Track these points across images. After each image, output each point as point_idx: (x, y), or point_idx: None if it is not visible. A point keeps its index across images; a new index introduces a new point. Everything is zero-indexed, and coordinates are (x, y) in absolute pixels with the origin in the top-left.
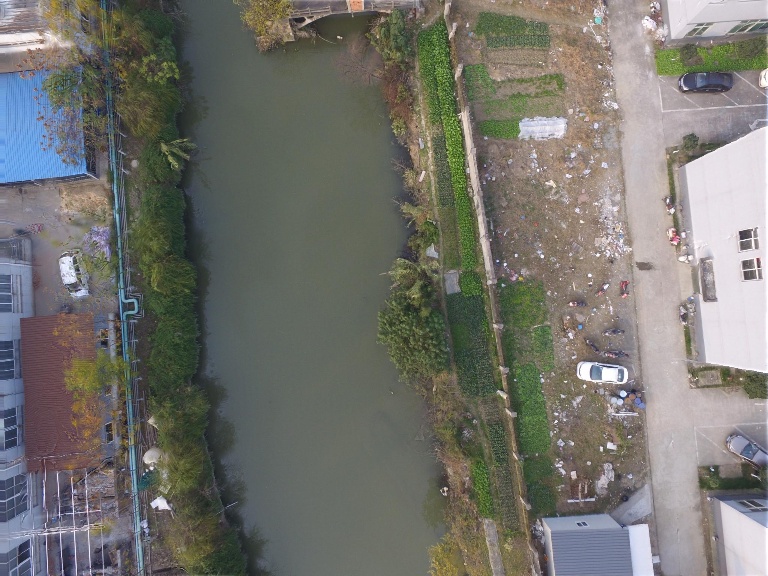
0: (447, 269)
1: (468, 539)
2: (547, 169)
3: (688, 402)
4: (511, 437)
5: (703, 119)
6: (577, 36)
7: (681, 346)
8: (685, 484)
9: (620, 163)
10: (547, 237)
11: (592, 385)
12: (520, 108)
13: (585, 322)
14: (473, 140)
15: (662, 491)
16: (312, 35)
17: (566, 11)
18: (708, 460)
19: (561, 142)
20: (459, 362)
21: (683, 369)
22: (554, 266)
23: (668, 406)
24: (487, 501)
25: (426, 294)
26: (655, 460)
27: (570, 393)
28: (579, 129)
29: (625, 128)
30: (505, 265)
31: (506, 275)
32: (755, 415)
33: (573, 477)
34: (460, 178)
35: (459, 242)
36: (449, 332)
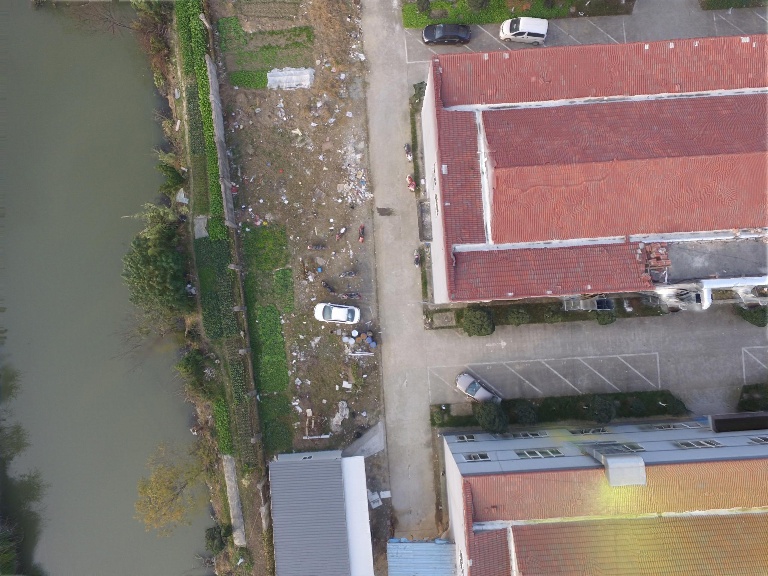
0: (196, 214)
1: (209, 475)
2: (294, 118)
3: (422, 343)
4: (250, 376)
5: None
6: None
7: (417, 289)
8: (417, 422)
9: (365, 112)
10: (292, 183)
11: (330, 326)
12: (270, 59)
13: (325, 265)
14: (222, 89)
15: (395, 428)
16: None
17: None
18: (440, 399)
19: (308, 92)
20: (204, 304)
21: (419, 311)
22: (297, 211)
23: (403, 346)
24: (225, 438)
25: (167, 237)
26: (389, 399)
27: (309, 334)
28: (325, 79)
29: (371, 79)
30: (250, 210)
31: (251, 220)
32: (486, 355)
33: (308, 415)
34: (210, 126)
35: (208, 188)
36: (197, 275)
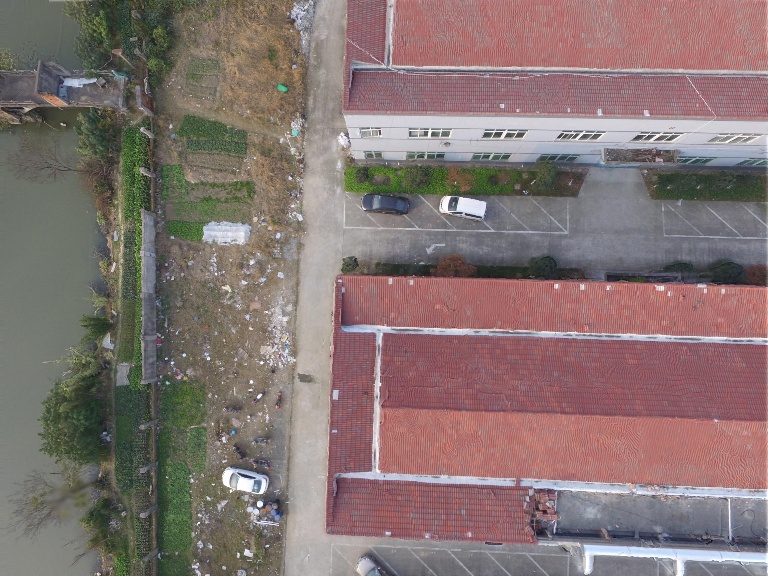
0: (120, 361)
1: None
2: (225, 273)
3: None
4: None
5: (382, 238)
6: (272, 146)
7: None
8: None
9: (296, 274)
10: (216, 340)
11: (238, 491)
12: (208, 211)
13: (240, 428)
14: (158, 239)
15: None
16: (38, 120)
17: (266, 121)
18: None
19: (242, 248)
20: (117, 453)
21: None
22: (219, 369)
23: (309, 520)
24: None
25: (86, 386)
26: (289, 572)
27: (216, 496)
28: (261, 237)
29: (306, 240)
30: (172, 363)
31: (172, 373)
32: None
33: None
34: None
35: (135, 336)
36: (114, 422)
